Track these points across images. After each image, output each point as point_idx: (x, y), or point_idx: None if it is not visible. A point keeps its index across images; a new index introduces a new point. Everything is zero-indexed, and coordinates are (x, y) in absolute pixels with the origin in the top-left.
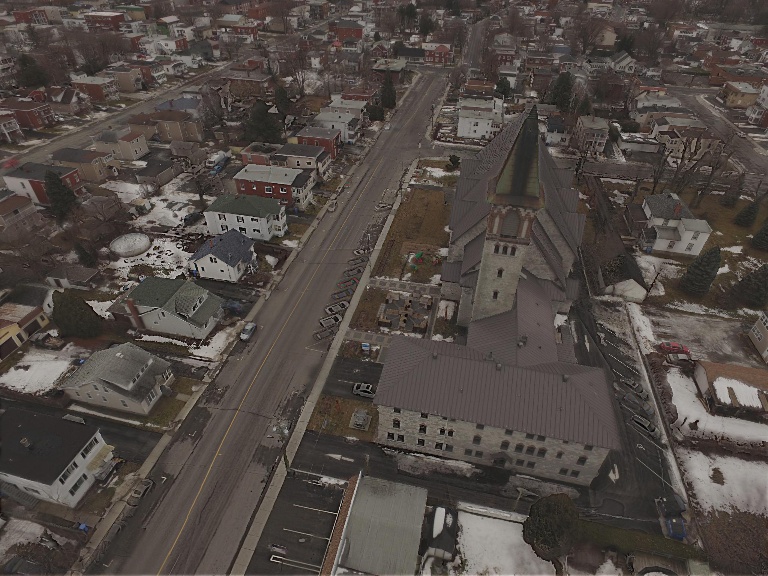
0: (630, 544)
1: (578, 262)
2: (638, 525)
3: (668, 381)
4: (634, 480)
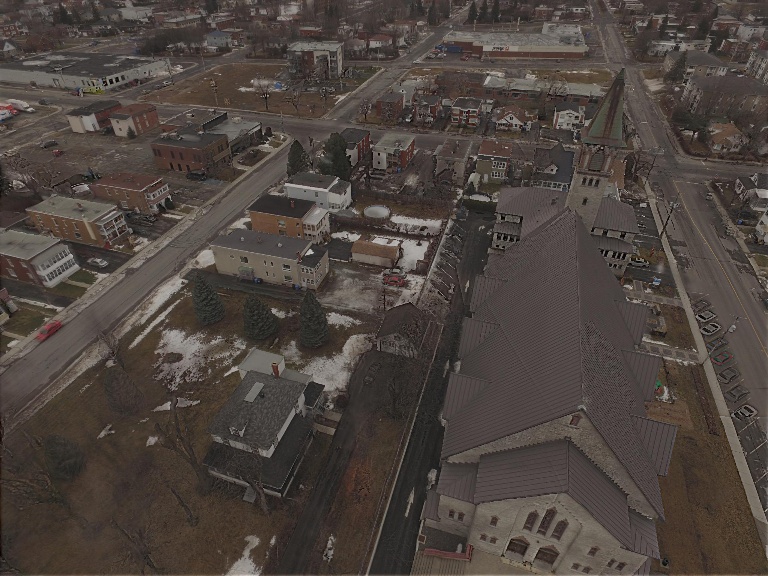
0: None
1: (434, 375)
2: None
3: None
4: None
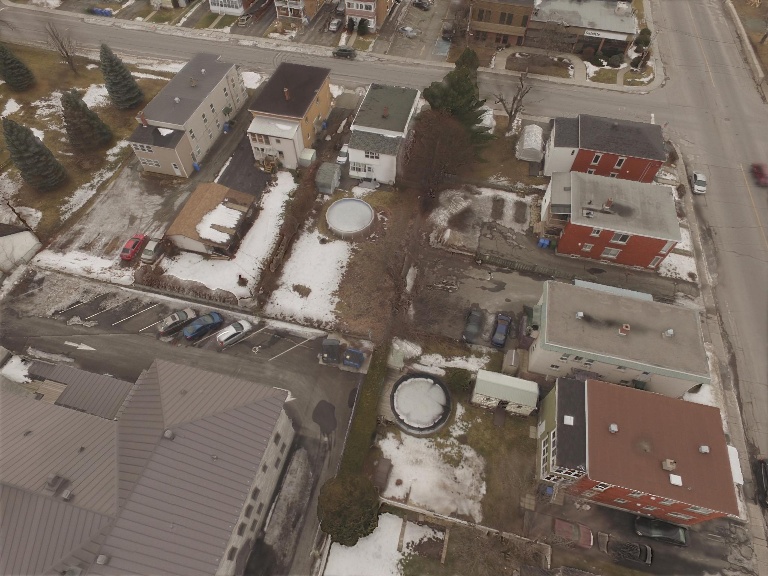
0: (372, 416)
1: None
2: (345, 394)
3: (178, 277)
4: (295, 375)
